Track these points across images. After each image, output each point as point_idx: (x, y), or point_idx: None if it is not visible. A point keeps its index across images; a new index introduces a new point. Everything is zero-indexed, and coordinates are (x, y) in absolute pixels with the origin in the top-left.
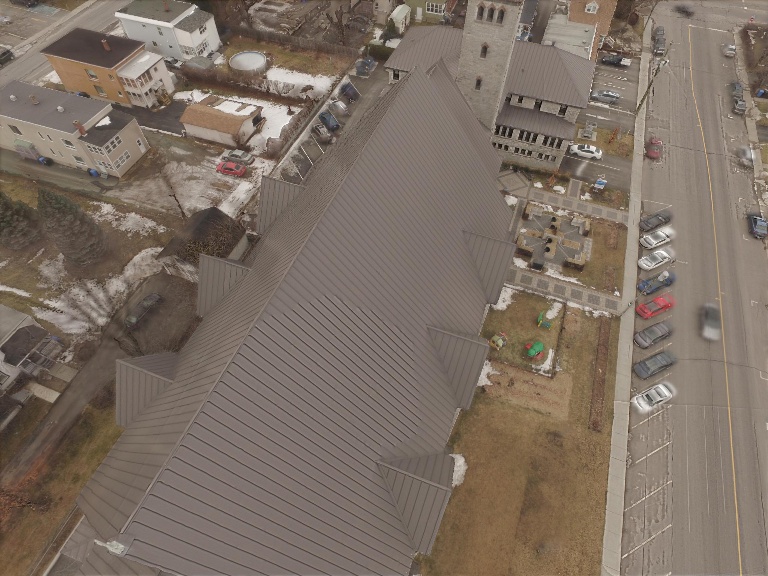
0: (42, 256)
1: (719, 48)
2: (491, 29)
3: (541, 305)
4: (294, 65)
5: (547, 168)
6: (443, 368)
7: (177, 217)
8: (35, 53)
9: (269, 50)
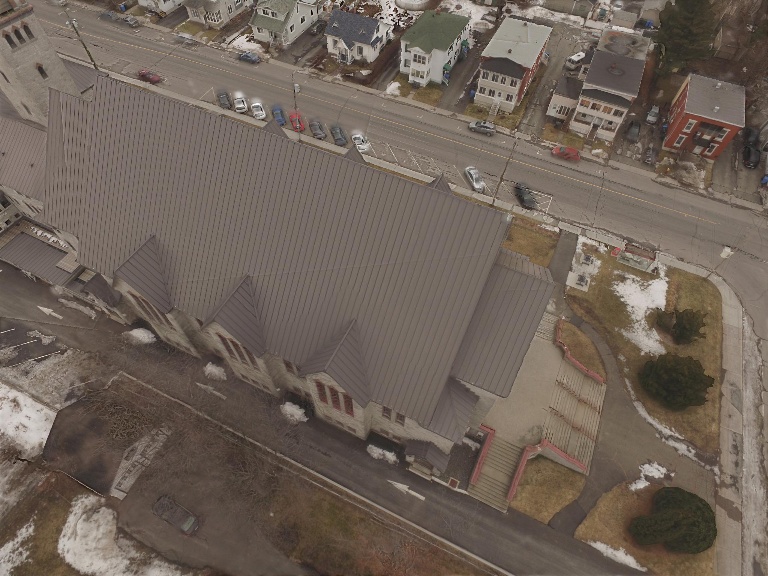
0: None
1: (49, 5)
2: (31, 48)
3: None
4: None
5: None
6: None
7: (14, 508)
8: None
9: None
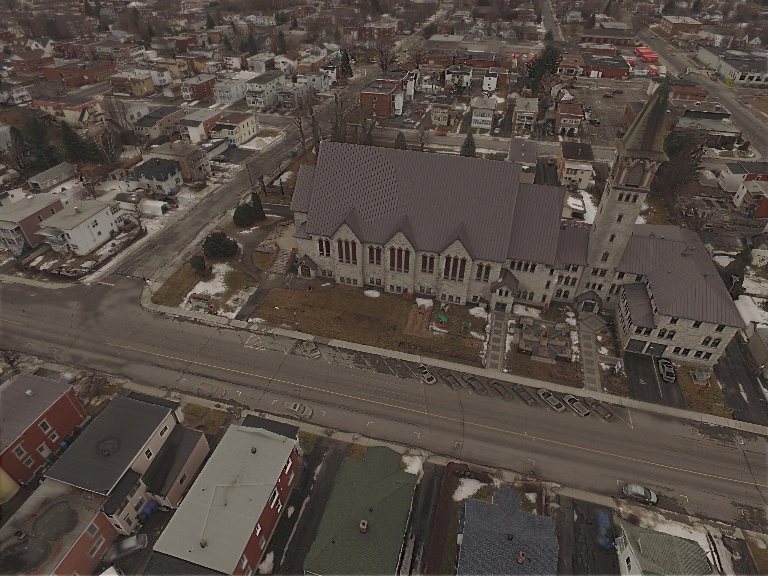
0: None
1: None
2: None
3: (480, 330)
4: (653, 223)
5: None
6: None
7: None
8: None
9: (660, 212)
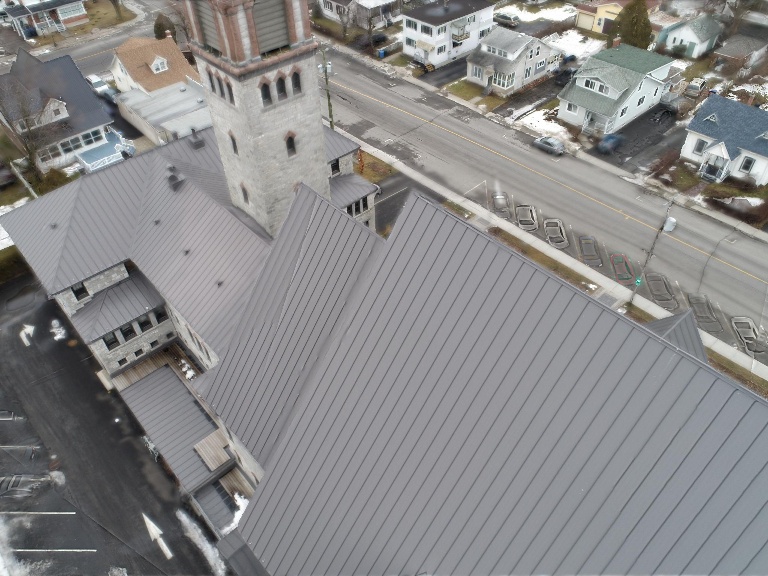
0: None
1: None
2: (289, 109)
3: None
4: None
5: None
6: None
7: None
8: None
9: None
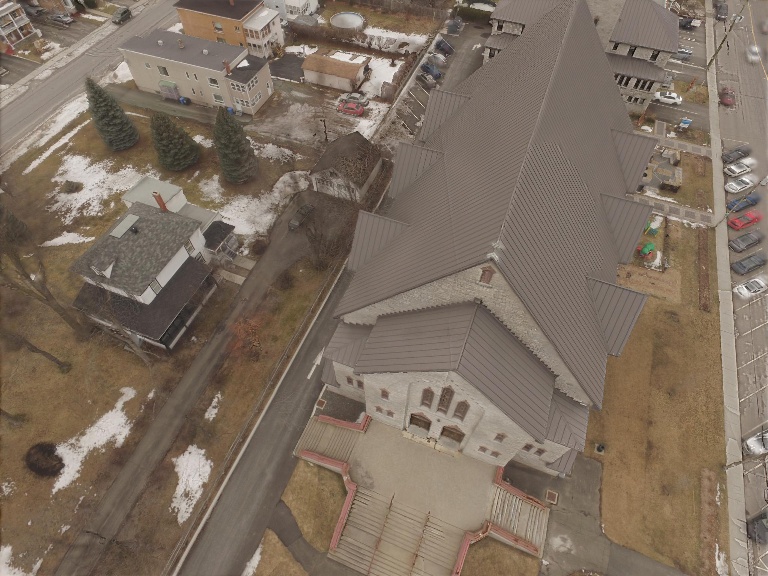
0: (199, 177)
1: None
2: None
3: None
4: (387, 25)
5: (634, 111)
6: (610, 229)
7: (311, 147)
8: (149, 13)
9: (362, 12)
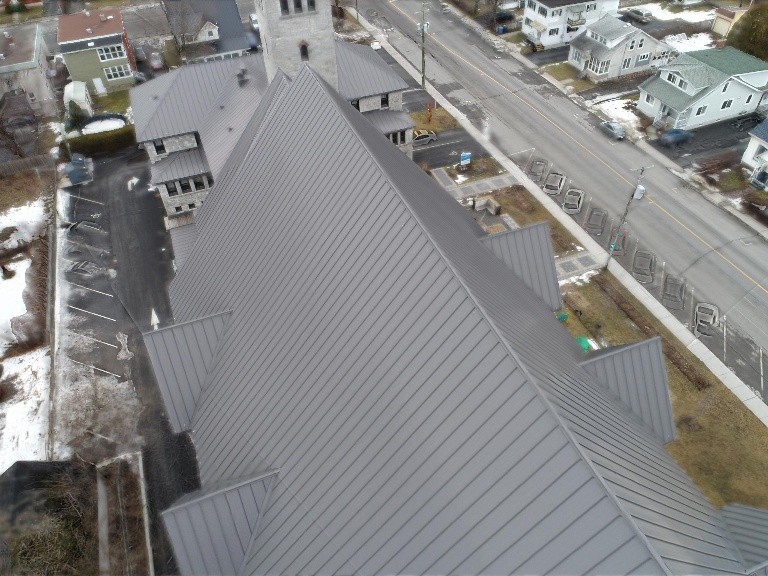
0: None
1: (432, 10)
2: (304, 21)
3: None
4: None
5: None
6: (624, 407)
7: None
8: None
9: None
